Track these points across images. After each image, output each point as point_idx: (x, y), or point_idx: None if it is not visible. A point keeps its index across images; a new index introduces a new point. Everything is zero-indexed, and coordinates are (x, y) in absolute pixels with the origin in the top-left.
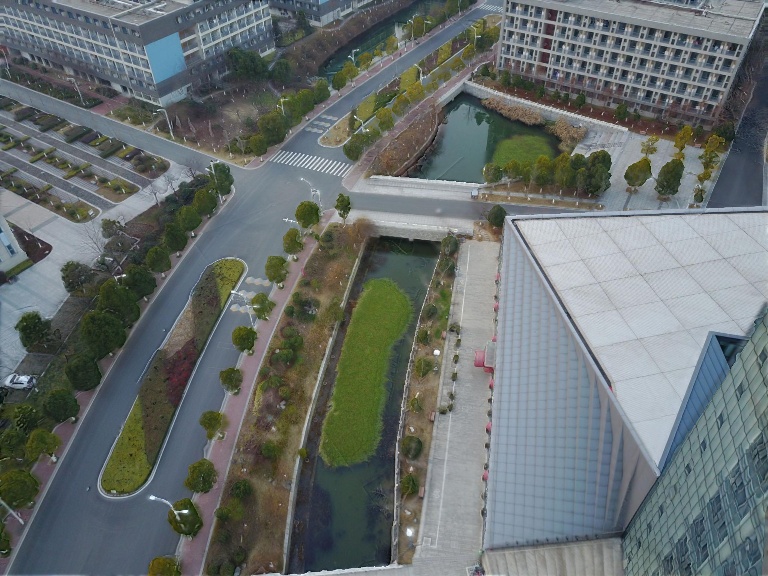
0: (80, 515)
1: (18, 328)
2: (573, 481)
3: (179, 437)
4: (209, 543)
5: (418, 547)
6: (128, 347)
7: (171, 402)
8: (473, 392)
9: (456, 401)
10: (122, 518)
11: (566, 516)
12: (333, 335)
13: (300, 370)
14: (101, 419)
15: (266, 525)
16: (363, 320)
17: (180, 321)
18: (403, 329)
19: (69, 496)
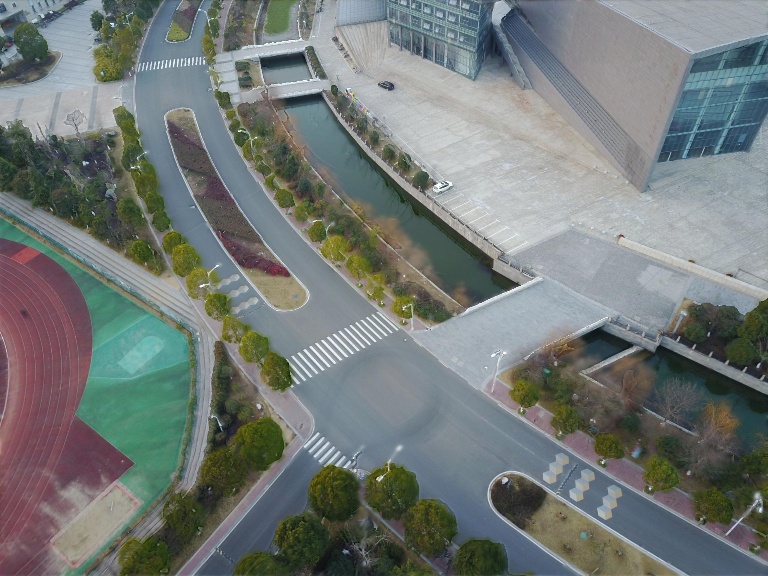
0: (162, 47)
1: (103, 1)
2: (369, 5)
3: (197, 29)
4: (222, 46)
5: (310, 37)
6: (159, 12)
7: (190, 19)
8: (331, 7)
9: (323, 9)
10: (182, 45)
11: (367, 15)
12: (262, 4)
13: (248, 10)
14: (158, 29)
15: (245, 43)
16: (276, 1)
17: (182, 3)
18: (297, 2)
19: (155, 44)
